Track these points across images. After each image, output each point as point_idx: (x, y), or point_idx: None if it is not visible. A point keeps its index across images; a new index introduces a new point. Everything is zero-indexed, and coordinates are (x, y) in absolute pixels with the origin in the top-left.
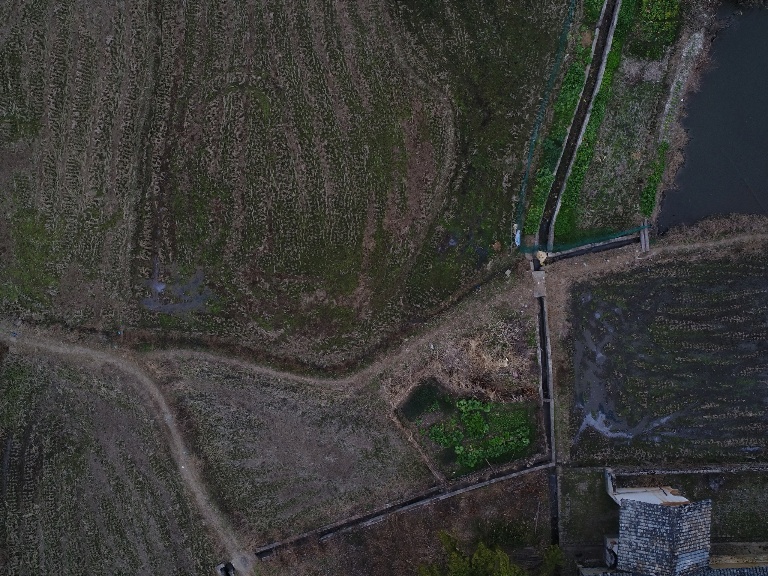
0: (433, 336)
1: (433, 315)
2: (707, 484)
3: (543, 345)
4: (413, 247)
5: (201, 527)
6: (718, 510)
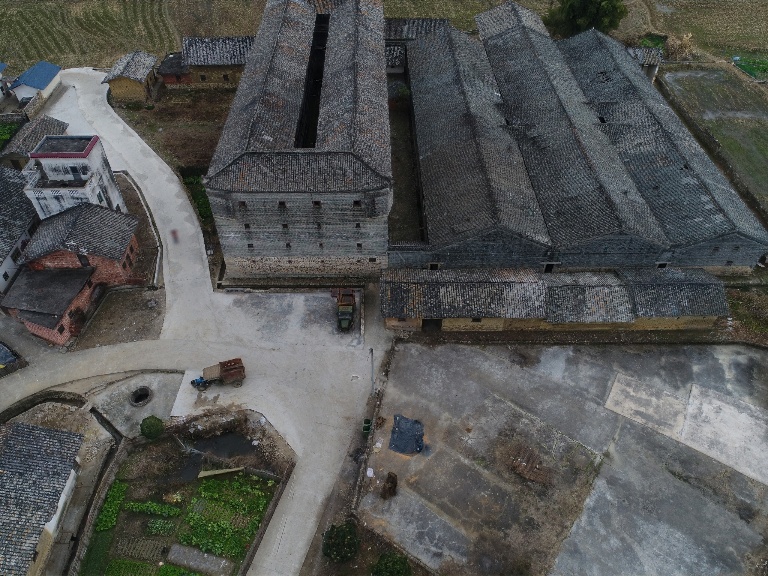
0: None
1: None
2: None
3: None
4: None
5: None
6: None
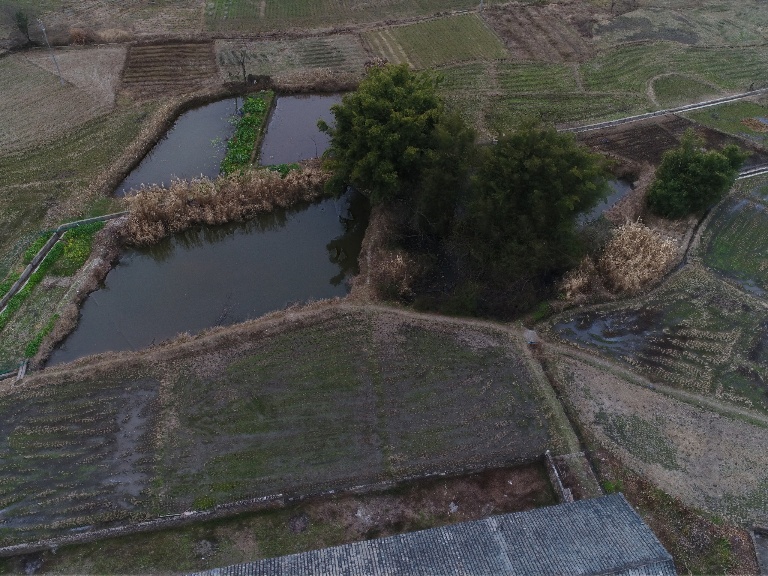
0: None
1: None
2: (23, 569)
3: None
4: None
5: None
6: None
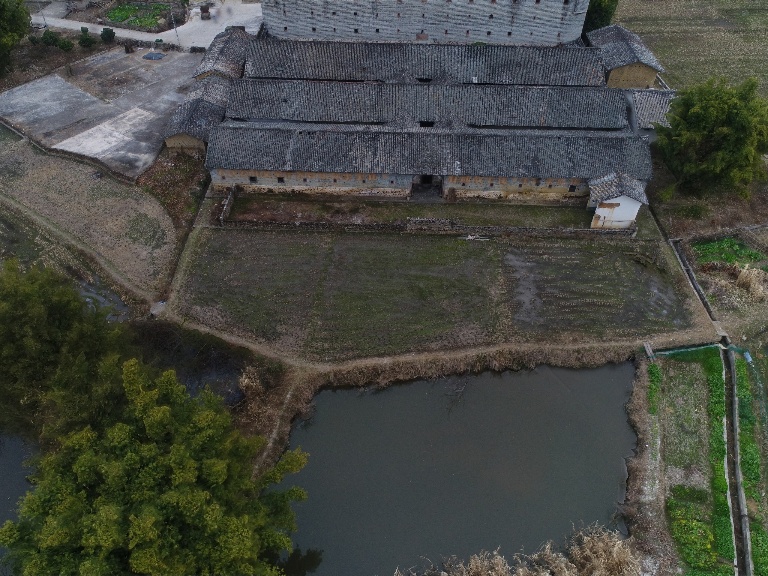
0: None
1: None
2: None
3: None
4: None
5: None
6: (557, 218)
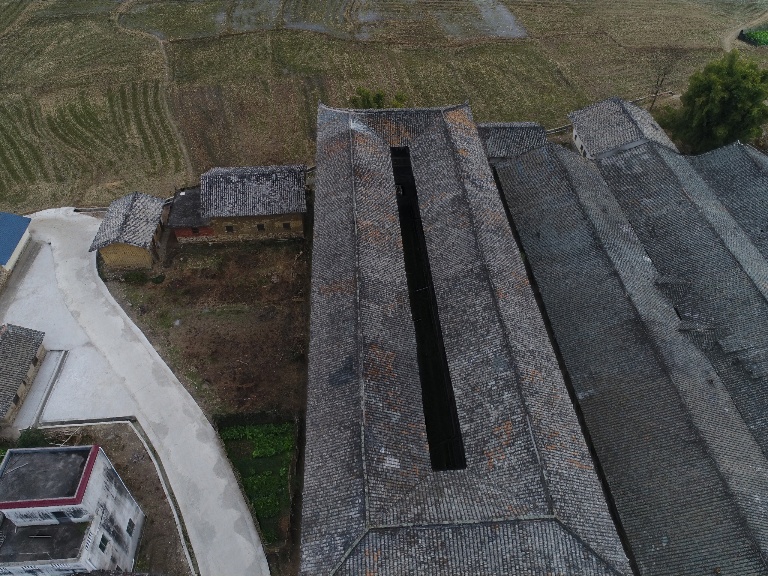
0: None
1: None
2: None
3: None
4: None
5: None
6: None
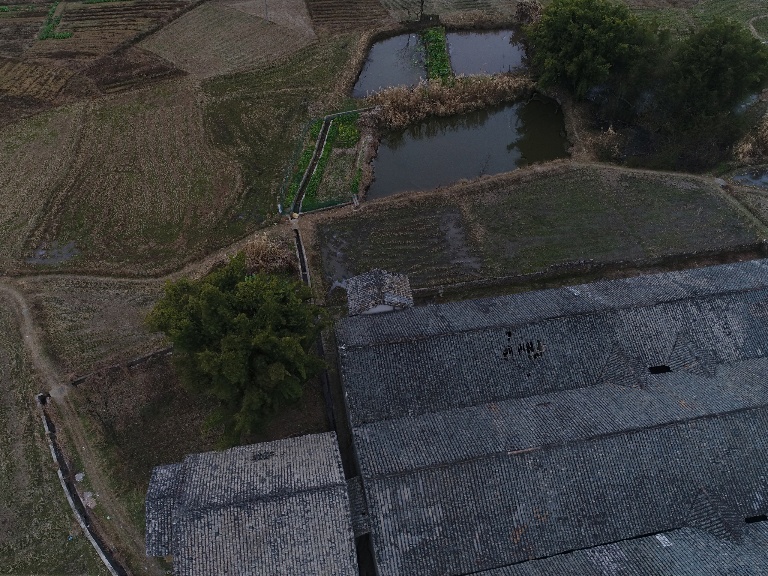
0: (226, 252)
1: (227, 246)
2: (425, 305)
3: (301, 252)
4: (215, 219)
5: (30, 371)
6: None
